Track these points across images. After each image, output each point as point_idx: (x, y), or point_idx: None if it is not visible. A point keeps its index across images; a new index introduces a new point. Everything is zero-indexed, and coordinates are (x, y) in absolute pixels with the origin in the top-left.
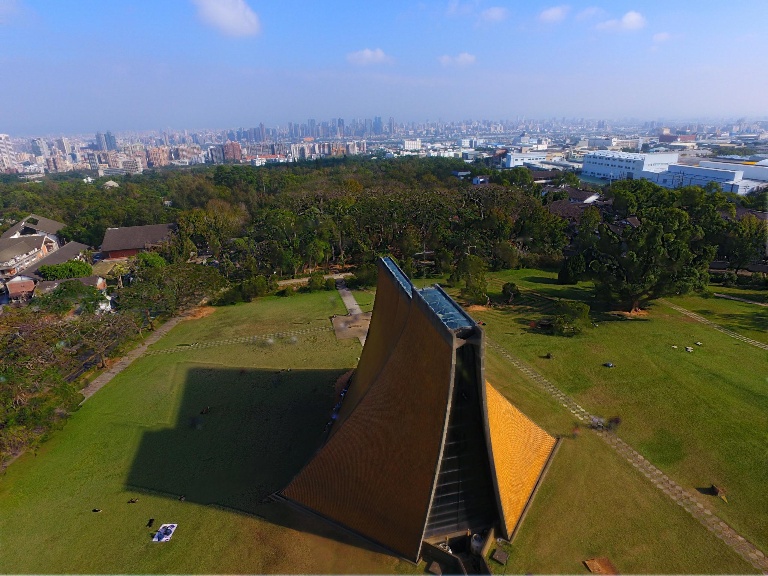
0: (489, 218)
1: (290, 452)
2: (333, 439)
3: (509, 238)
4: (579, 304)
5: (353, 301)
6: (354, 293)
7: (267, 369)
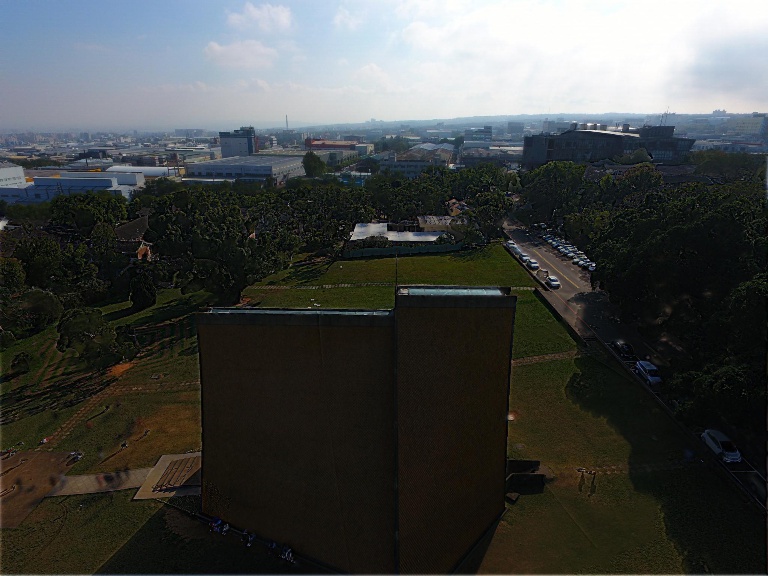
0: None
1: None
2: (402, 506)
3: (23, 285)
4: None
5: None
6: None
7: None
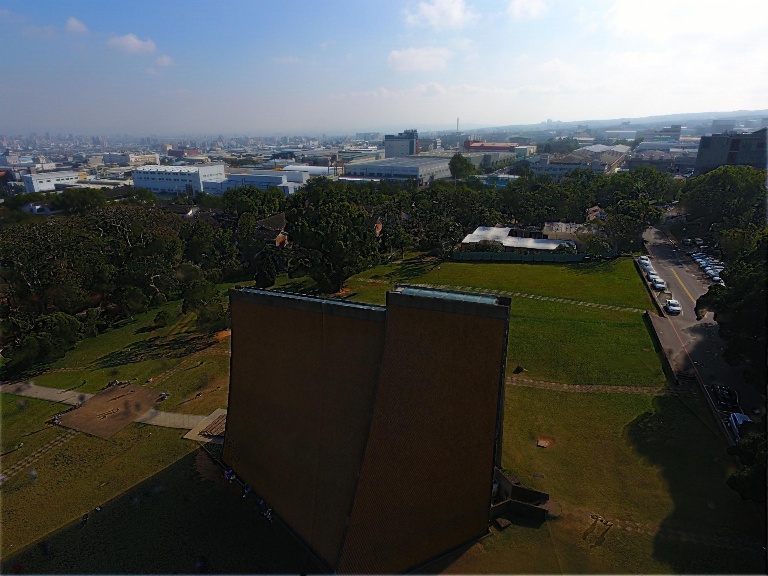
0: (154, 242)
1: (268, 570)
2: (358, 495)
3: (181, 259)
4: (322, 295)
5: (50, 390)
6: (31, 382)
7: (53, 533)
